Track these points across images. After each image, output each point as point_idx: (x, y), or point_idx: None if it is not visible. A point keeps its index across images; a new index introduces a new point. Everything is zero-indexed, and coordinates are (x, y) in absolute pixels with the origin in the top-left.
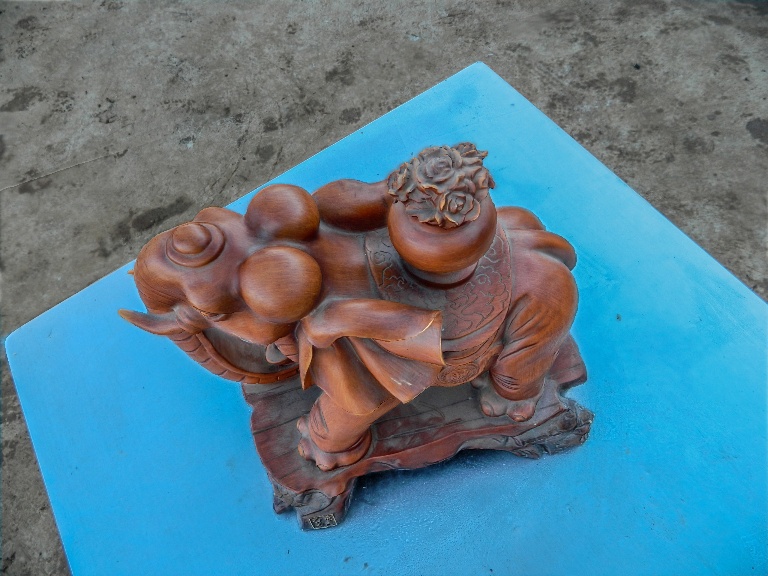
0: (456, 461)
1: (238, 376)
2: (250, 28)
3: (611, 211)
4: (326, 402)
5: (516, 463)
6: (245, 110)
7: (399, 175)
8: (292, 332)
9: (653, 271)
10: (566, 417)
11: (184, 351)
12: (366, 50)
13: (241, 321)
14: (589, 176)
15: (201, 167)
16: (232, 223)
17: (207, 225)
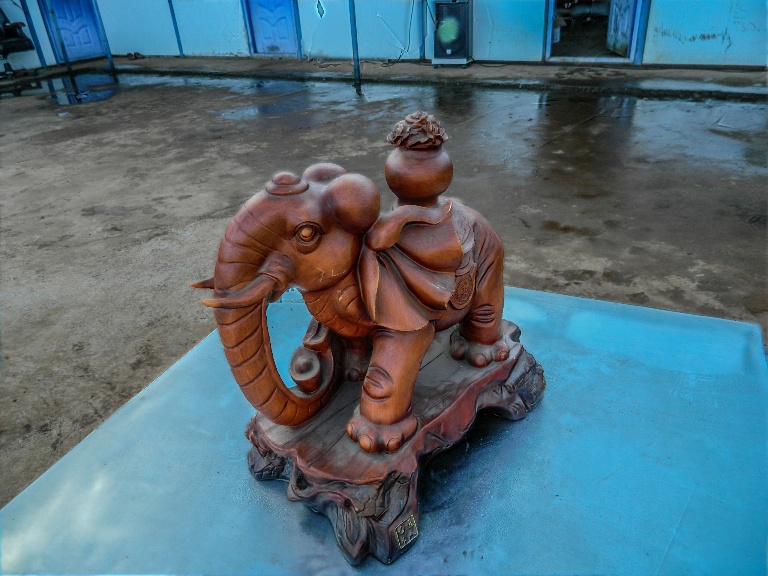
0: (473, 448)
1: (283, 399)
2: (29, 359)
3: None
4: (382, 353)
5: (514, 427)
6: (50, 419)
7: (396, 129)
8: (356, 264)
9: None
10: (527, 355)
11: (240, 368)
12: (163, 339)
13: (328, 245)
14: None
15: (12, 484)
16: None
17: None
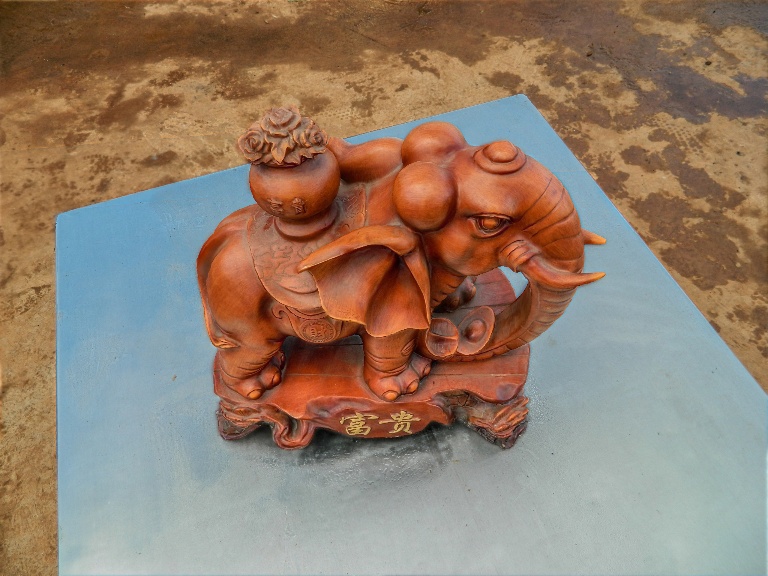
0: None
1: None
2: None
3: (100, 495)
4: None
5: None
6: None
7: (313, 136)
8: None
9: (115, 413)
10: None
11: None
12: None
13: None
14: (87, 556)
15: None
16: (468, 176)
17: (488, 164)
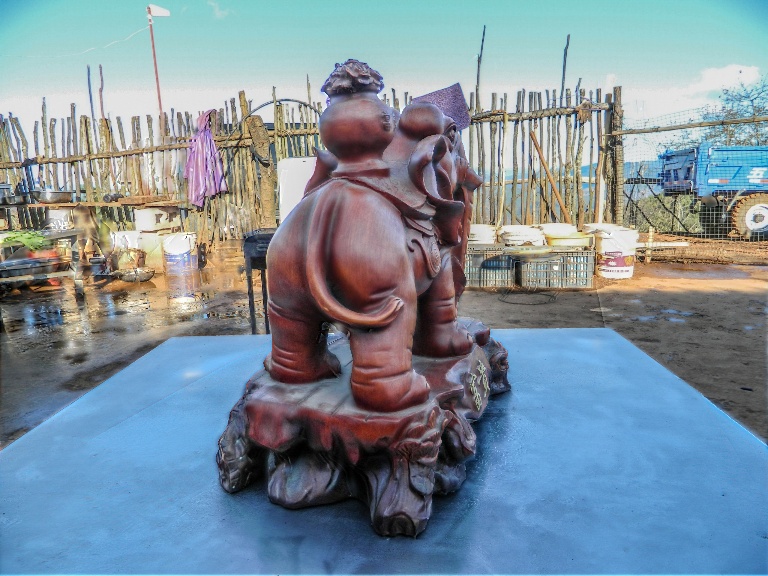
0: None
1: None
2: None
3: None
4: None
5: None
6: None
7: None
8: None
9: None
10: None
11: None
12: None
13: None
14: None
15: None
16: None
17: None
